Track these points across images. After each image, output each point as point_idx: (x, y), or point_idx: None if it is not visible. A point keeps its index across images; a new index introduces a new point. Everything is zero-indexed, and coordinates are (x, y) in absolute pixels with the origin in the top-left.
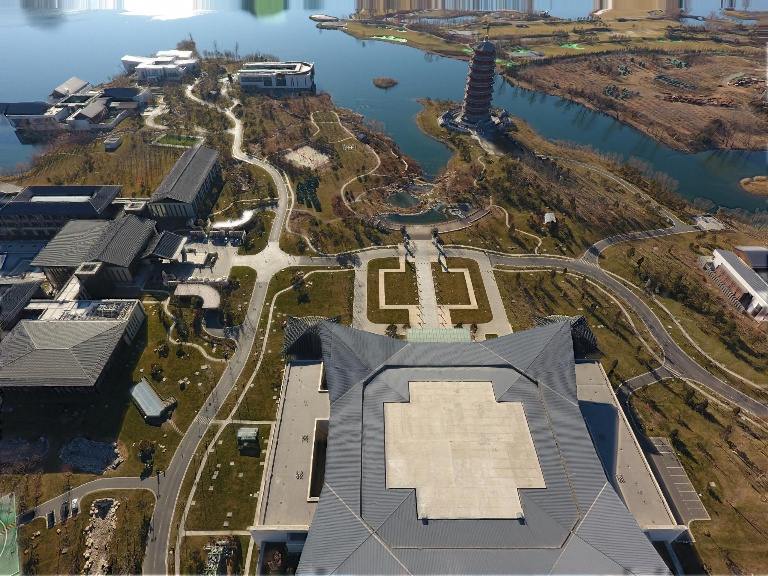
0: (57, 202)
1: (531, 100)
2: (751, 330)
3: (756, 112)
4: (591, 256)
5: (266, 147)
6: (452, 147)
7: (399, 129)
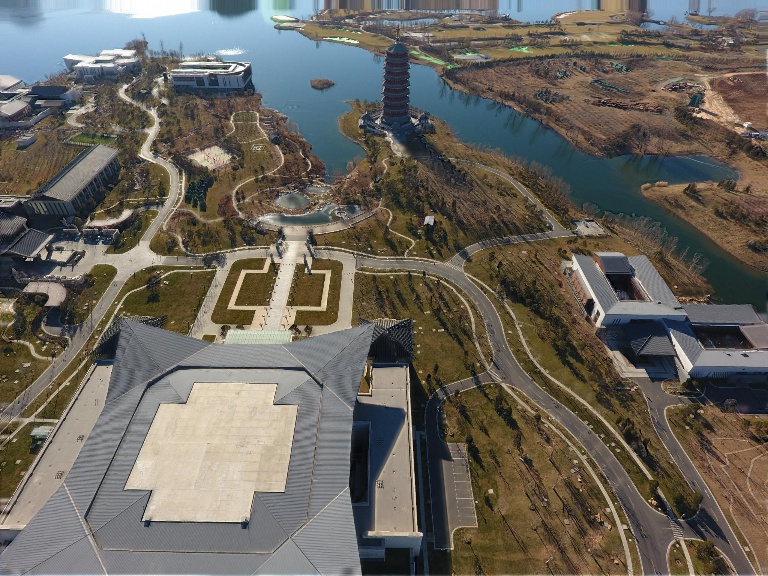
0: None
1: (466, 103)
2: (587, 336)
3: (679, 117)
4: (459, 259)
5: (175, 146)
6: (365, 149)
7: (319, 130)
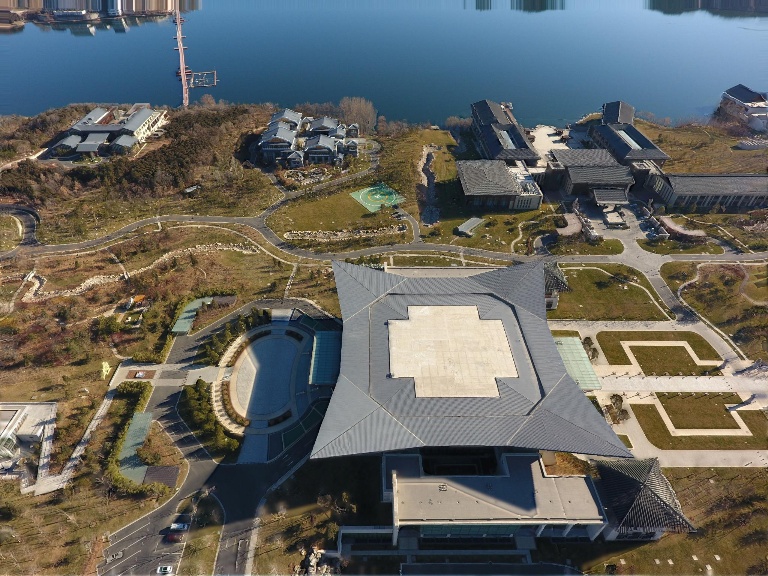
0: (621, 138)
1: None
2: None
3: None
4: None
5: None
6: None
7: None
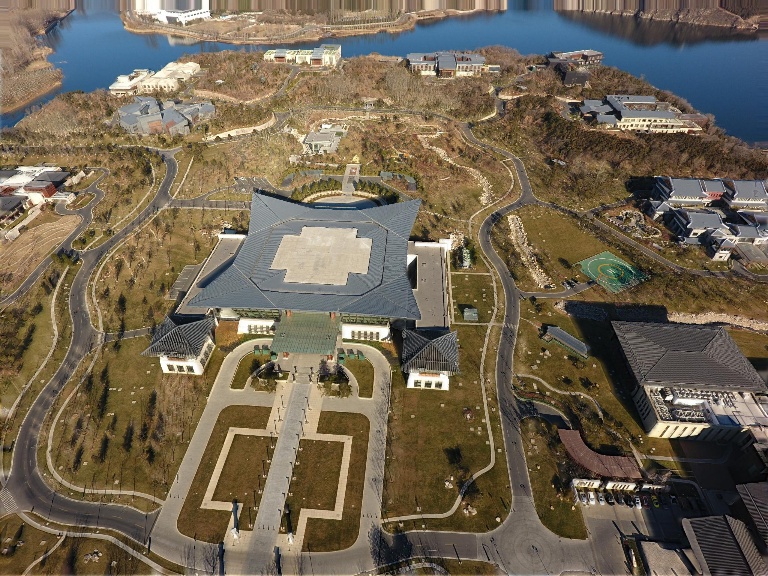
0: None
1: None
2: None
3: None
4: None
5: None
6: None
7: None
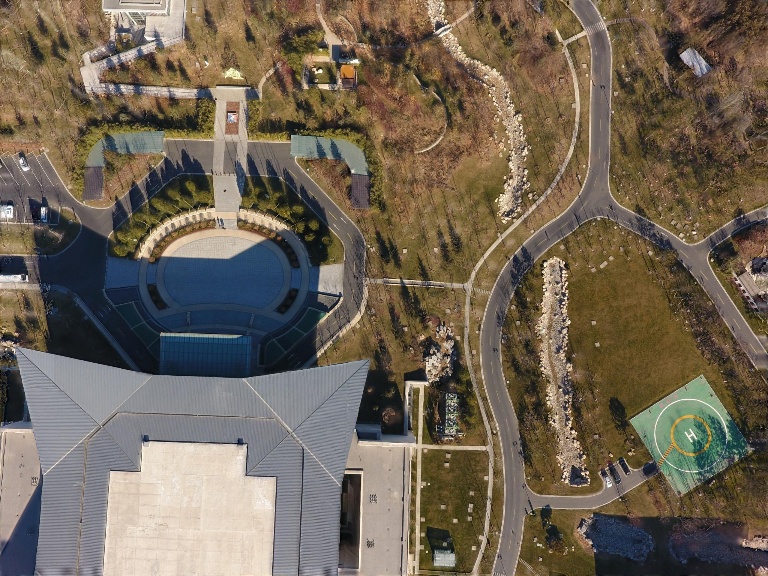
0: None
1: None
2: None
3: None
4: None
5: None
6: None
7: None
